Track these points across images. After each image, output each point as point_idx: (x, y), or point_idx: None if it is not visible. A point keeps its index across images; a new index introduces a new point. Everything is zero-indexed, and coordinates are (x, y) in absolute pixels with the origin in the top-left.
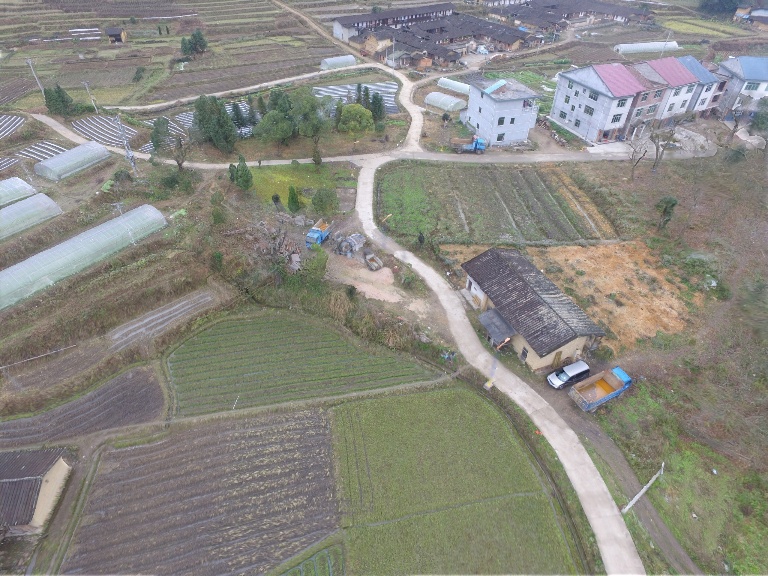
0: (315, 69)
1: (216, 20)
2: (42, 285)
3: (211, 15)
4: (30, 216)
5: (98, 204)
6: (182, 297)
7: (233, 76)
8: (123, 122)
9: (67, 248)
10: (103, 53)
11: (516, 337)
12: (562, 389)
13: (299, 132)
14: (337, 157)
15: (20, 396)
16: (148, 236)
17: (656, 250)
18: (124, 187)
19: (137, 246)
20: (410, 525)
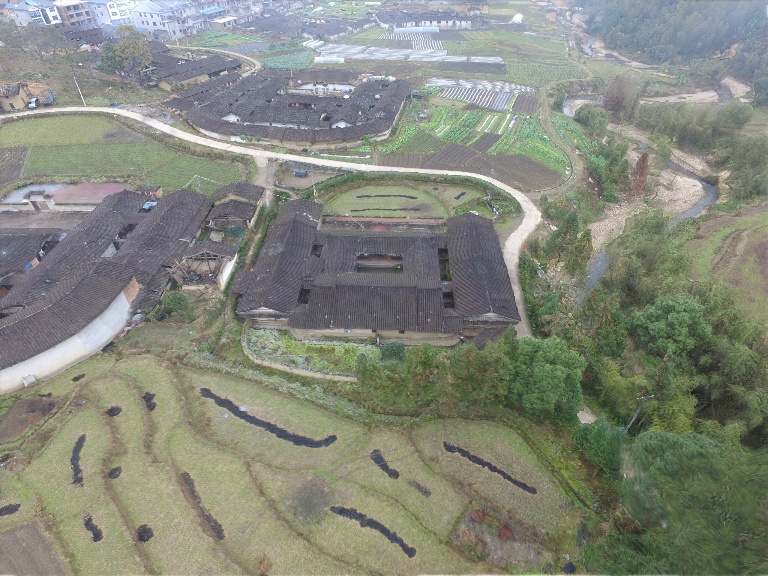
0: None
1: None
2: None
3: None
4: None
5: None
6: None
7: None
8: None
9: None
10: None
11: (2, 104)
12: (38, 107)
13: None
14: None
15: None
16: None
17: (8, 80)
18: None
19: None
20: (45, 136)
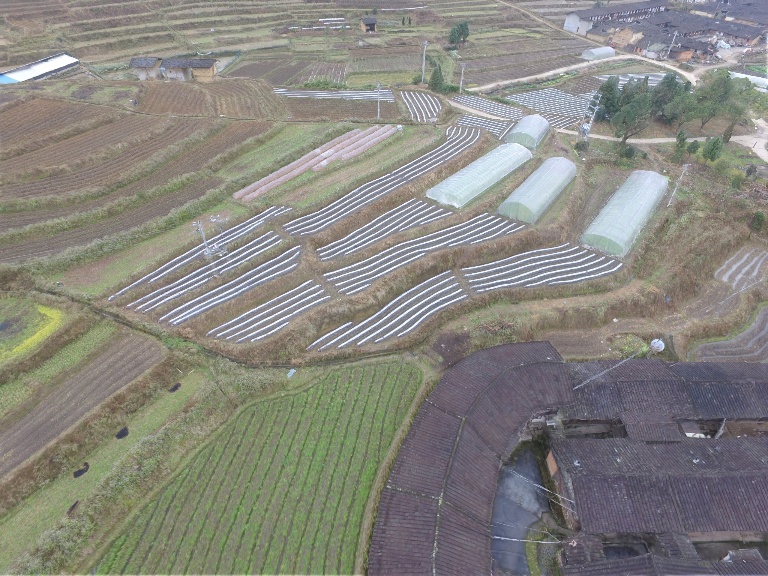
0: (580, 59)
1: (446, 12)
2: (637, 234)
3: (439, 7)
4: (569, 176)
5: (587, 169)
6: (739, 250)
7: (514, 64)
8: (494, 101)
9: (633, 203)
10: (369, 41)
11: None
12: None
13: (718, 111)
14: None
15: (711, 322)
16: (663, 198)
17: None
18: None
19: (672, 205)
20: None
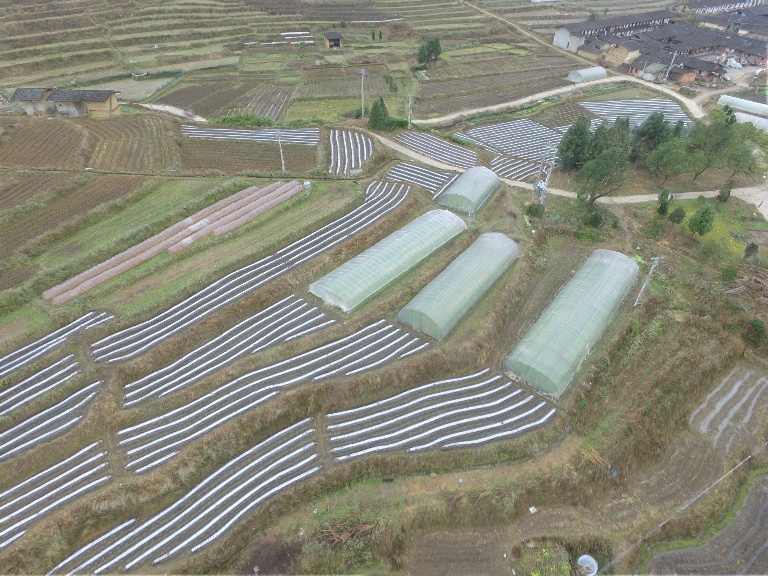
0: (566, 81)
1: (423, 25)
2: (584, 355)
3: (416, 19)
4: (504, 261)
5: (537, 245)
6: (728, 375)
7: (488, 87)
8: (446, 140)
9: (584, 307)
10: (330, 59)
11: None
12: None
13: (713, 164)
14: (717, 191)
15: (675, 516)
16: (631, 290)
17: None
18: (544, 224)
19: (640, 305)
20: None
